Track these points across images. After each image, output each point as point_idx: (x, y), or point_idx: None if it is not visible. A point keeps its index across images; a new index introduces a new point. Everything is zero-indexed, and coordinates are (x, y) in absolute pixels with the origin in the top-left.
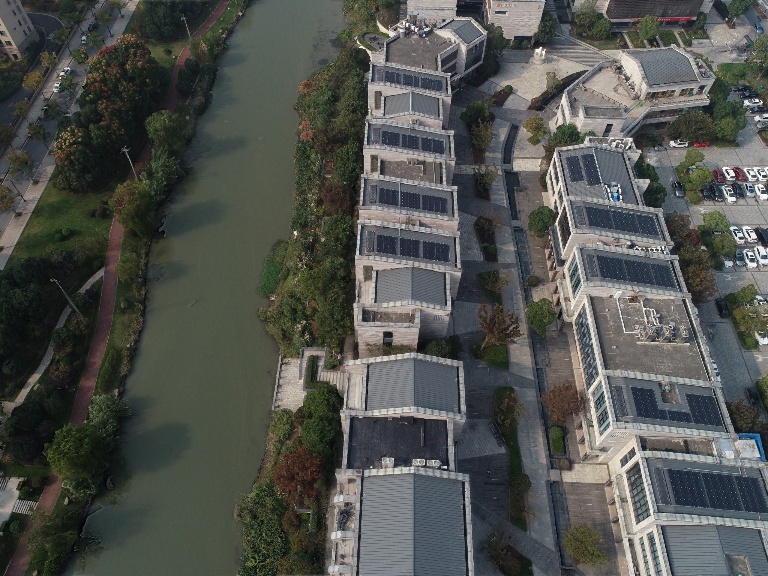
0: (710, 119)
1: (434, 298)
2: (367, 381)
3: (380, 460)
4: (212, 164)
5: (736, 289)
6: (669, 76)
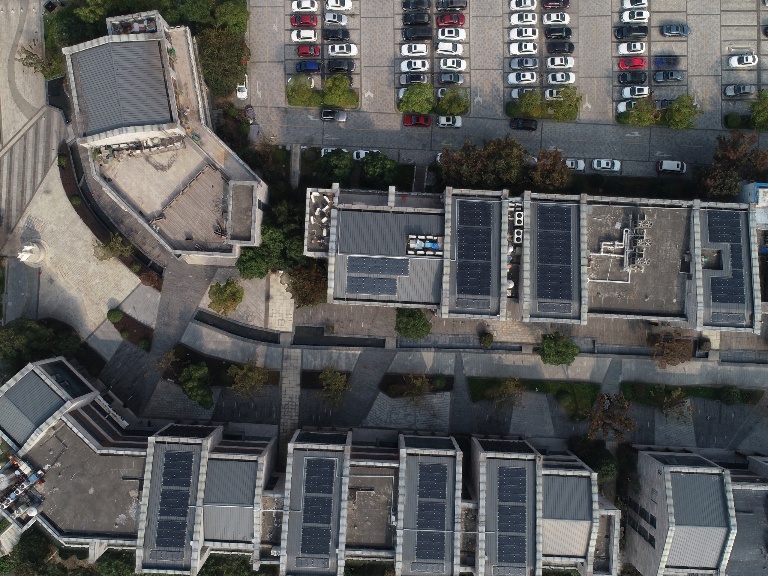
0: (214, 34)
1: (580, 491)
2: (683, 568)
3: (766, 555)
4: None
5: (496, 97)
6: (151, 85)
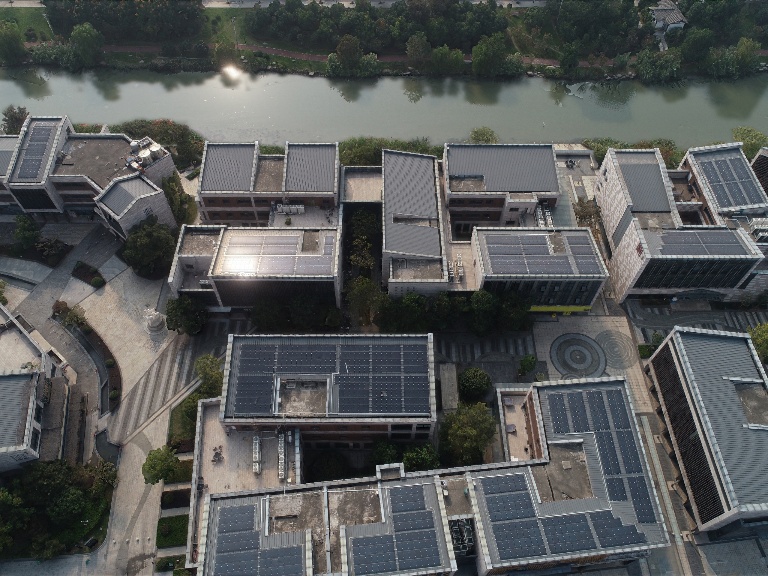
0: None
1: None
2: None
3: None
4: (82, 84)
5: None
6: None
